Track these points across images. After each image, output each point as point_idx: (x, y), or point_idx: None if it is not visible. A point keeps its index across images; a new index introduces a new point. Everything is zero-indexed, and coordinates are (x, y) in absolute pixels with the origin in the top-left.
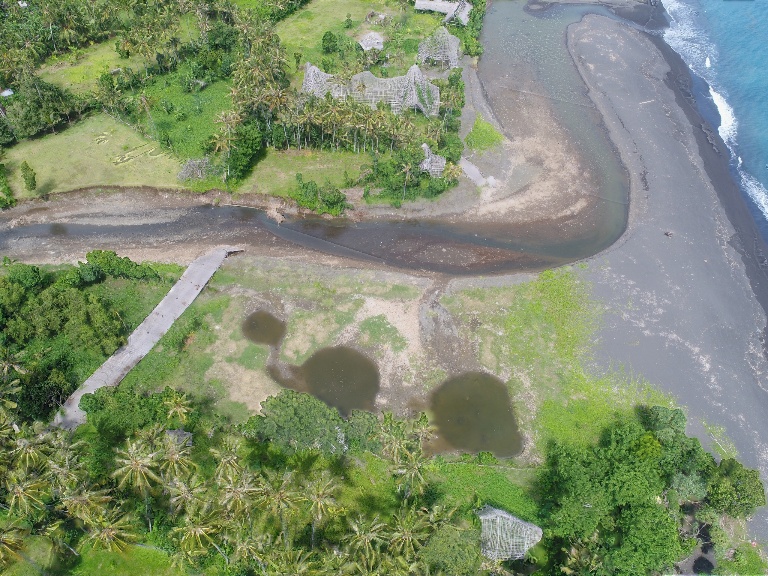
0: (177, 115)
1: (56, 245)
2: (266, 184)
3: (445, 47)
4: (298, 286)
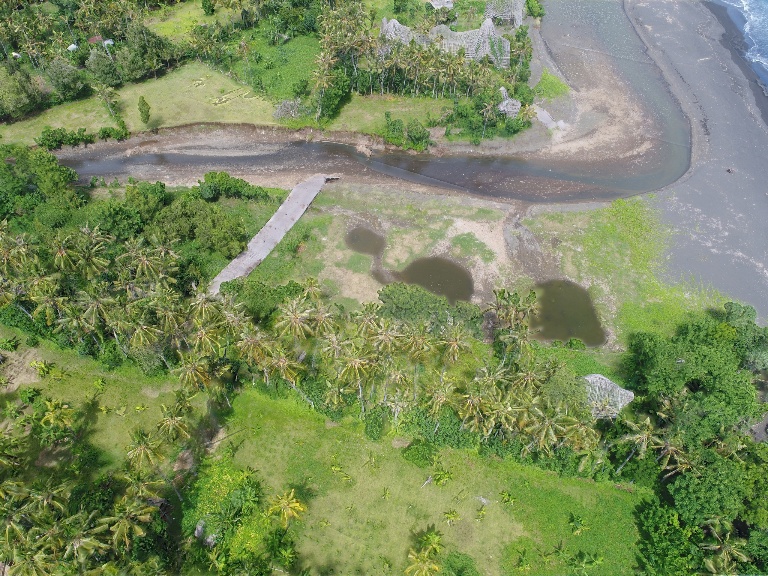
0: (266, 63)
1: (170, 171)
2: (354, 123)
3: (511, 6)
4: (392, 208)
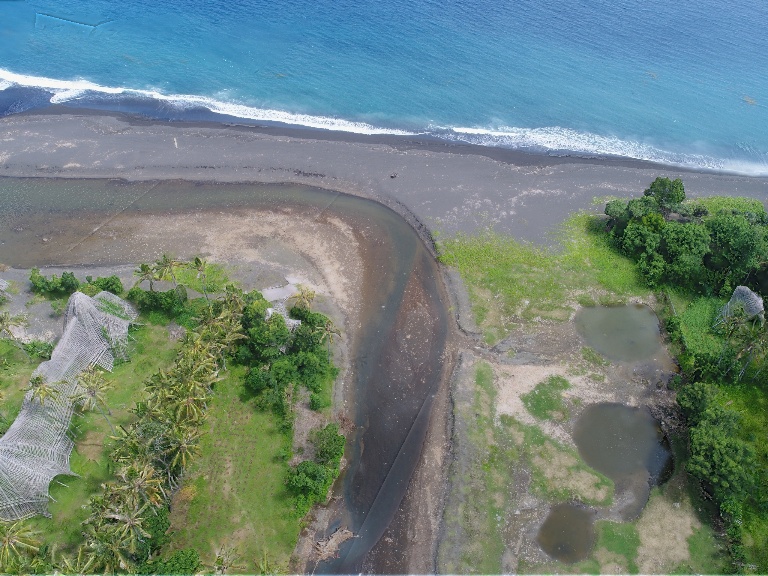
0: None
1: None
2: None
3: None
4: (490, 492)
